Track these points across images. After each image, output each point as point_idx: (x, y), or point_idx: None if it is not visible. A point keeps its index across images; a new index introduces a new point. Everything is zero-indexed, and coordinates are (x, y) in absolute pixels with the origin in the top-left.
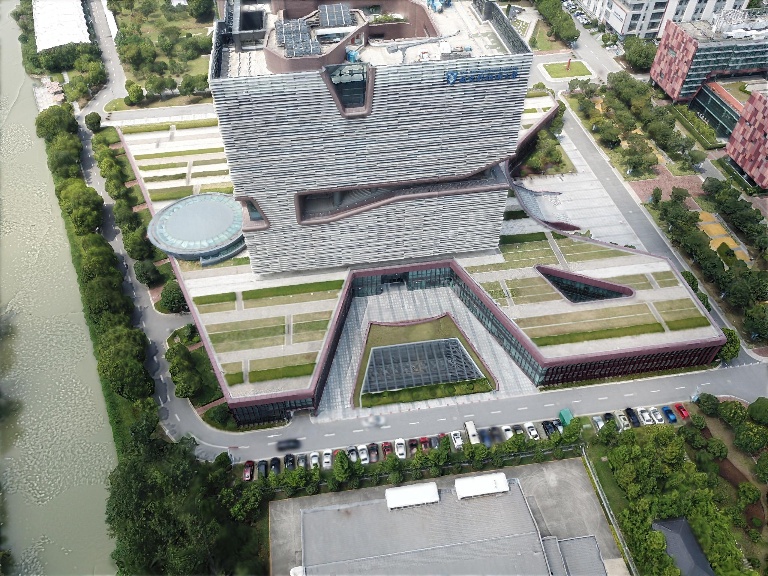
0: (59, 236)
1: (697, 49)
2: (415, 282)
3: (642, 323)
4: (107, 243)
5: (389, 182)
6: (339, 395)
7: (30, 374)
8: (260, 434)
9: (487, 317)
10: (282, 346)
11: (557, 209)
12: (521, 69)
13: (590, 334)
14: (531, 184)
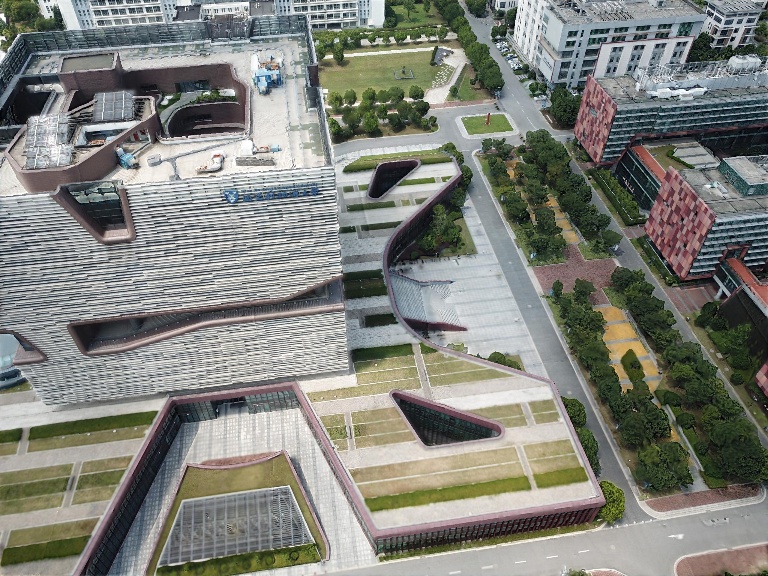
0: None
1: (616, 111)
2: (256, 405)
3: (505, 476)
4: None
5: (187, 308)
6: (132, 566)
7: None
8: None
9: None
10: (57, 509)
11: (445, 302)
12: (322, 184)
13: (438, 493)
14: (421, 269)
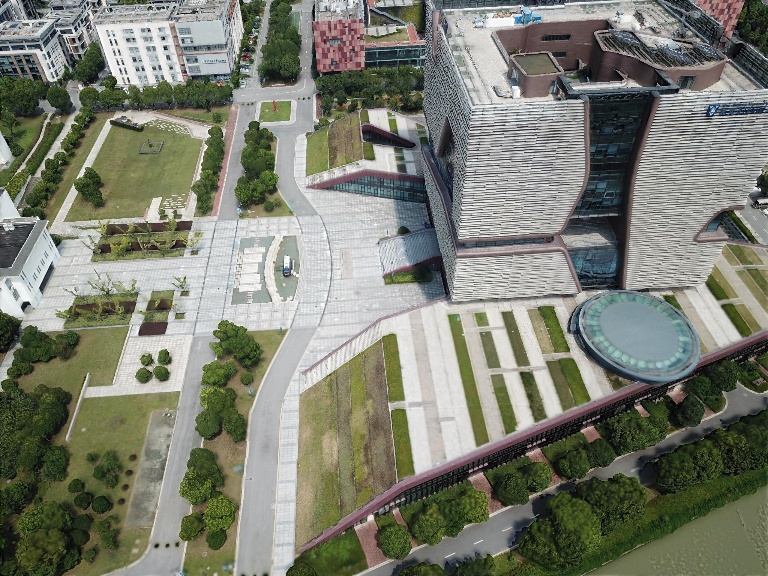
0: None
1: None
2: None
3: None
4: None
5: None
6: None
7: None
8: None
9: None
10: None
11: None
12: None
13: None
14: None
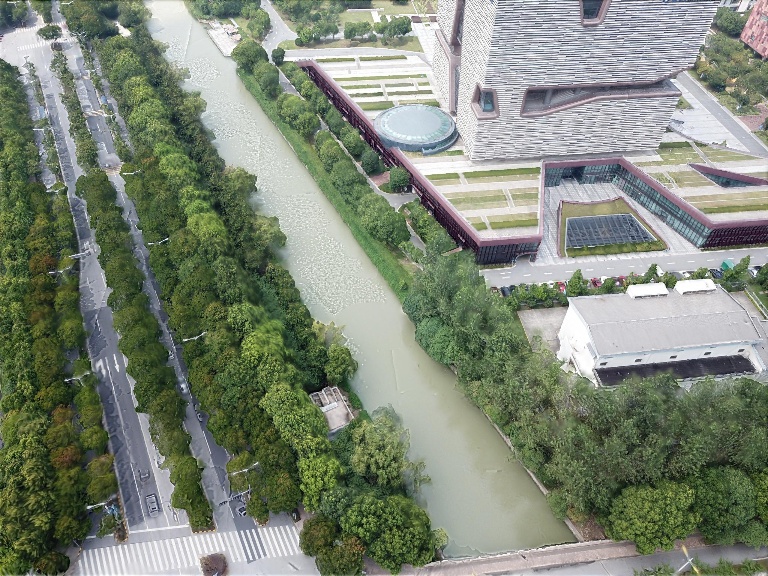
0: (271, 142)
1: None
2: (587, 177)
3: None
4: (334, 140)
5: (597, 83)
6: (547, 249)
7: (294, 231)
8: (494, 272)
9: (652, 200)
10: (508, 208)
11: (684, 133)
12: None
13: (743, 207)
14: None
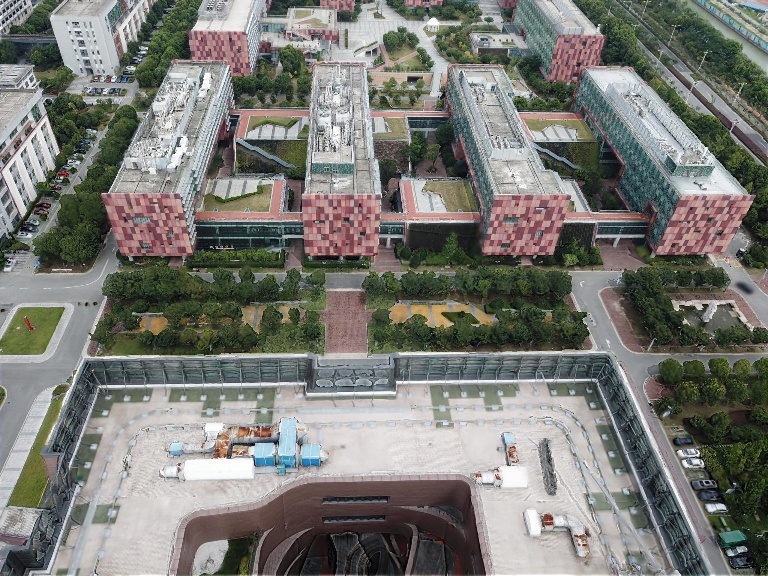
0: None
1: None
2: None
3: None
4: None
5: None
6: None
7: None
8: None
9: None
10: None
11: None
12: None
13: None
14: None
